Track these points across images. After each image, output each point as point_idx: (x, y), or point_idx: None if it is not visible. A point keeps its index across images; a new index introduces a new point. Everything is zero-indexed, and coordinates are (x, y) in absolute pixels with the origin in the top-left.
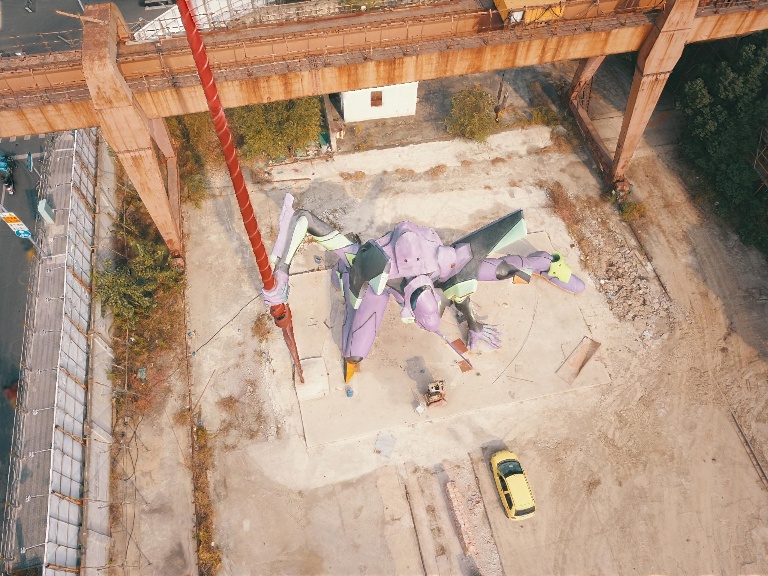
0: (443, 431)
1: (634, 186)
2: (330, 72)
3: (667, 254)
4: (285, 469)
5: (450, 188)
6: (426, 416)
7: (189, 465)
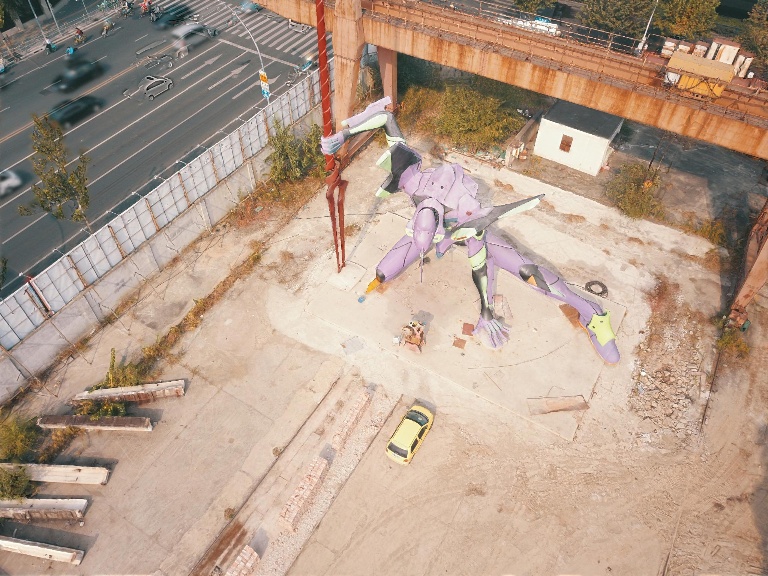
0: (400, 368)
1: (759, 332)
2: (496, 59)
3: (737, 399)
4: (280, 312)
5: (573, 234)
6: (397, 350)
7: (233, 269)
